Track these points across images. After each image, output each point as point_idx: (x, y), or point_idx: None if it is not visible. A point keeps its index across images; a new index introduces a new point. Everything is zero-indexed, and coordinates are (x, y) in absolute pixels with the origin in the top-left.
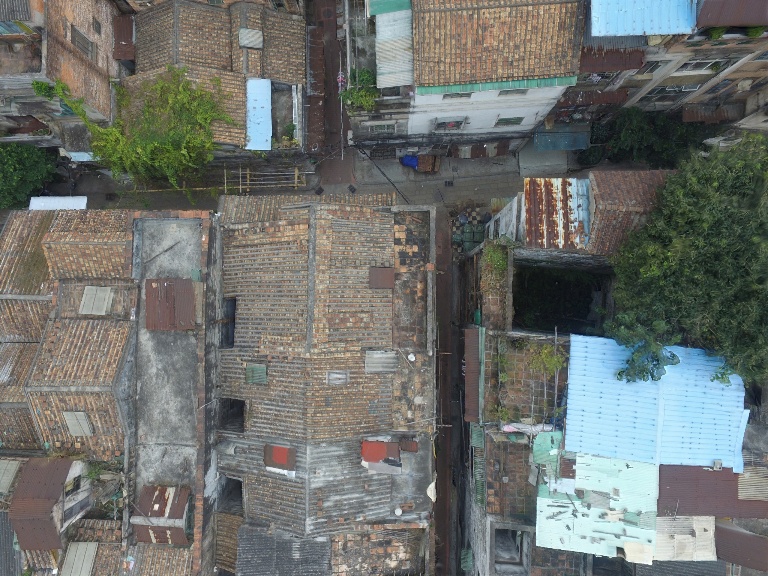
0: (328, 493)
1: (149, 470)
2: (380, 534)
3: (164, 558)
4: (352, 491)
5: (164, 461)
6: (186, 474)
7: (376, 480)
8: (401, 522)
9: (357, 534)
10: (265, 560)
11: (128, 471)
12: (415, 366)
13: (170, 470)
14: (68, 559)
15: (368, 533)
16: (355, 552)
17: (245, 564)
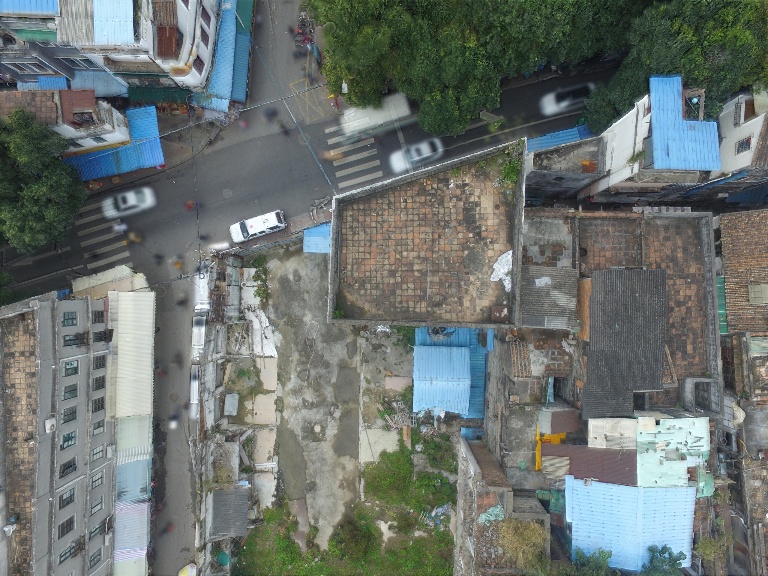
0: None
1: None
2: None
3: None
4: None
5: None
6: None
7: None
8: None
9: None
10: None
11: None
12: (763, 509)
13: None
14: None
15: None
16: None
17: None
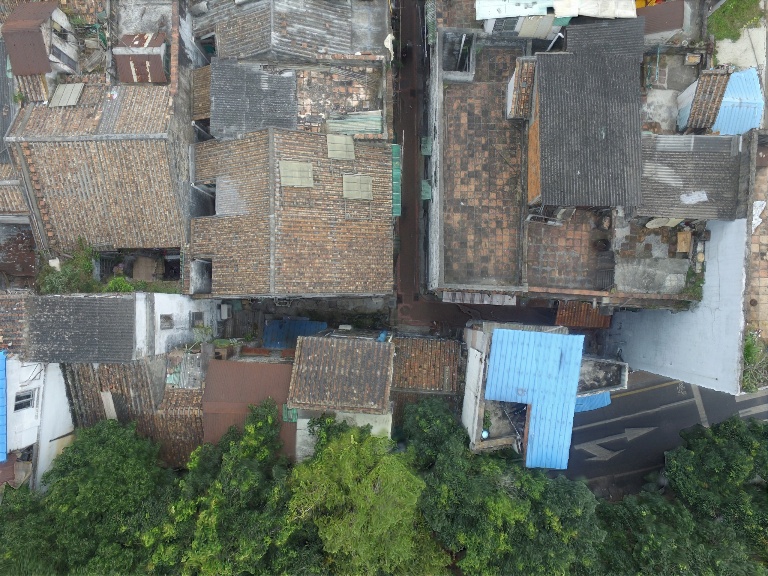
0: (292, 19)
1: (130, 28)
2: (341, 74)
3: (145, 92)
4: (314, 25)
5: (143, 20)
6: (164, 29)
7: (337, 24)
8: (360, 55)
9: (320, 72)
10: (236, 89)
11: (110, 18)
12: None
13: (149, 27)
14: (57, 93)
15: (330, 72)
16: (319, 88)
17: (218, 90)
